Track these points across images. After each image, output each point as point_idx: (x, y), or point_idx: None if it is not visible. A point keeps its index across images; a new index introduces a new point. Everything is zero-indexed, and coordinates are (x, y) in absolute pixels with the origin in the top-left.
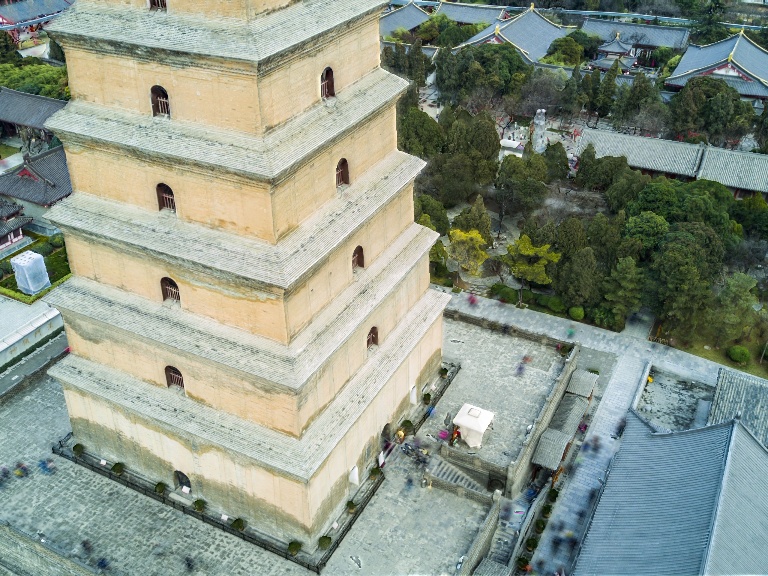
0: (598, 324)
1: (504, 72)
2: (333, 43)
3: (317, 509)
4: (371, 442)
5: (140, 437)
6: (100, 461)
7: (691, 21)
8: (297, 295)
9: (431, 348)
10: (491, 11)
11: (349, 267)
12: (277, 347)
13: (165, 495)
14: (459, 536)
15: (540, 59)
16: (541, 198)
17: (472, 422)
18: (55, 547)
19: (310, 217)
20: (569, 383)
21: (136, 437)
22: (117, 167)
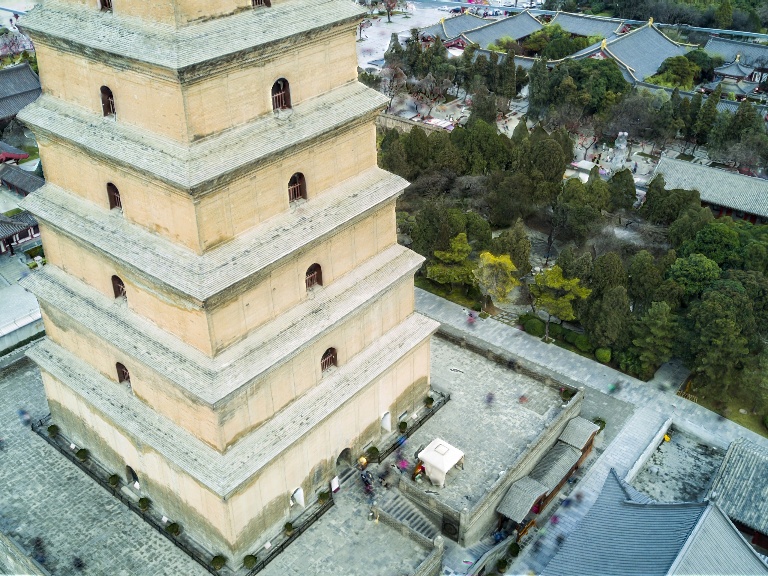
0: (623, 370)
1: (600, 89)
2: (289, 54)
3: (243, 527)
4: (323, 465)
5: (99, 427)
6: (70, 444)
7: None
8: (226, 308)
9: (412, 375)
10: (609, 24)
11: (301, 284)
12: (203, 359)
13: (117, 487)
14: None
15: (646, 78)
16: (596, 227)
17: (437, 459)
18: (3, 522)
19: (251, 230)
20: (563, 431)
21: (96, 427)
22: (76, 163)
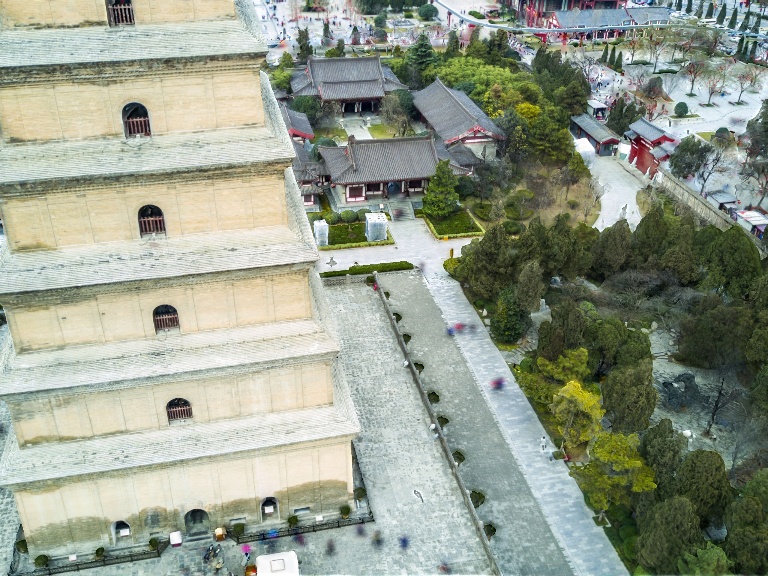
0: None
1: None
2: (147, 79)
3: (41, 526)
4: (161, 512)
5: None
6: None
7: None
8: (34, 313)
9: (318, 472)
10: None
11: (147, 320)
12: None
13: None
14: None
15: None
16: None
17: (265, 571)
18: None
19: (80, 247)
20: None
21: None
22: None
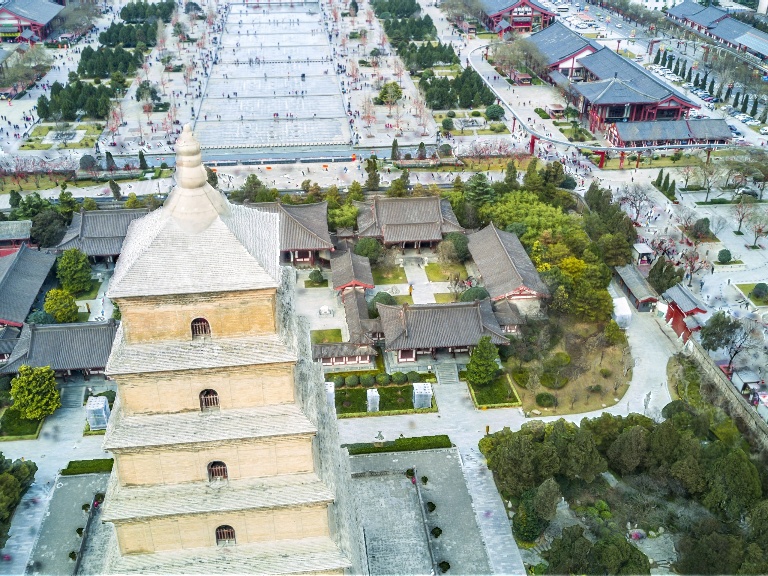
0: None
1: None
2: (227, 447)
3: None
4: None
5: None
6: None
7: None
8: None
9: None
10: None
11: None
12: None
13: None
14: None
15: None
16: None
17: None
18: None
19: (172, 551)
20: None
21: None
22: None
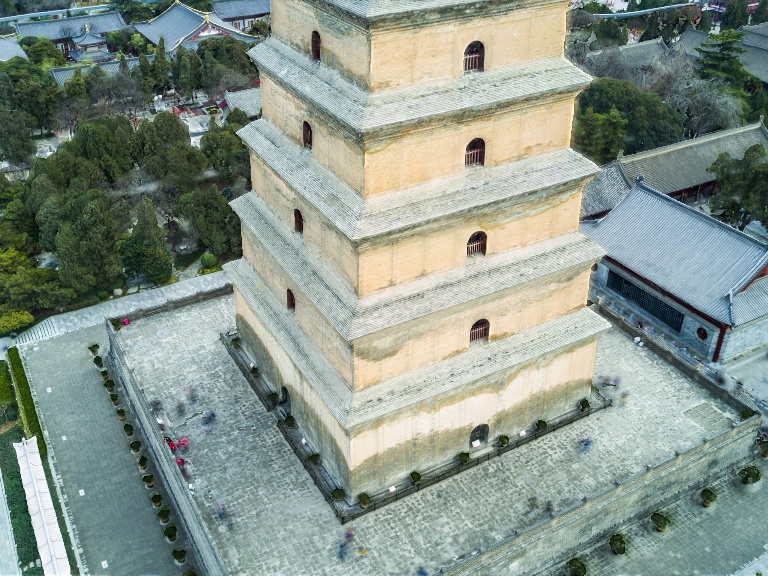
0: None
1: None
2: None
3: None
4: None
5: (441, 422)
6: (388, 491)
7: (110, 4)
8: None
9: None
10: None
11: None
12: (572, 236)
13: None
14: (612, 335)
15: None
16: None
17: None
18: None
19: None
20: None
21: (437, 426)
22: (429, 144)
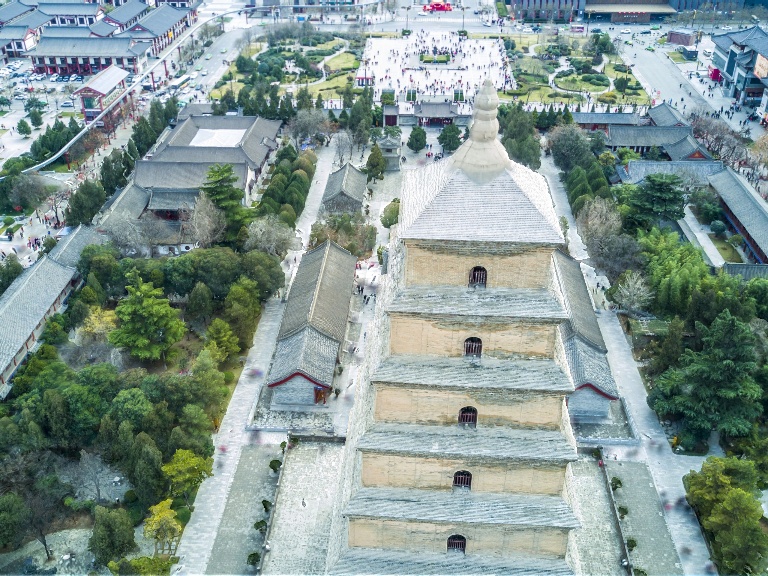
0: None
1: None
2: None
3: None
4: None
5: None
6: None
7: None
8: None
9: None
10: None
11: None
12: None
13: None
14: None
15: None
16: None
17: None
18: None
19: None
20: None
21: None
22: None
